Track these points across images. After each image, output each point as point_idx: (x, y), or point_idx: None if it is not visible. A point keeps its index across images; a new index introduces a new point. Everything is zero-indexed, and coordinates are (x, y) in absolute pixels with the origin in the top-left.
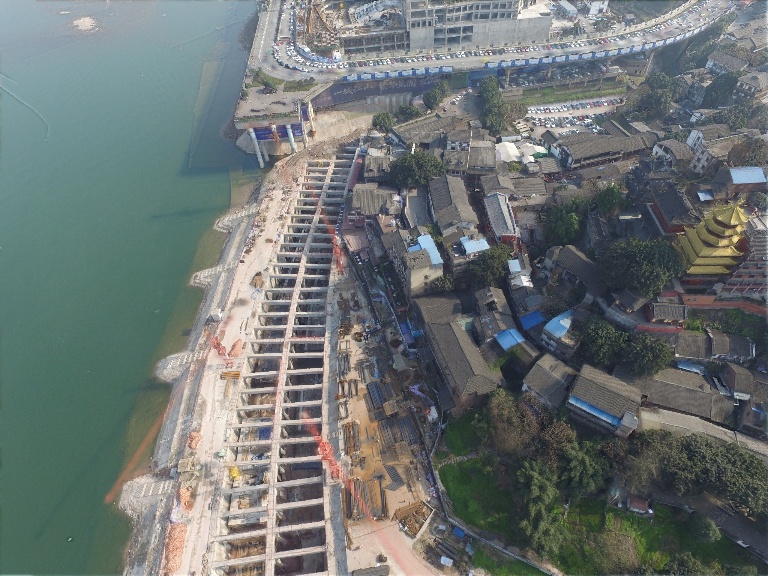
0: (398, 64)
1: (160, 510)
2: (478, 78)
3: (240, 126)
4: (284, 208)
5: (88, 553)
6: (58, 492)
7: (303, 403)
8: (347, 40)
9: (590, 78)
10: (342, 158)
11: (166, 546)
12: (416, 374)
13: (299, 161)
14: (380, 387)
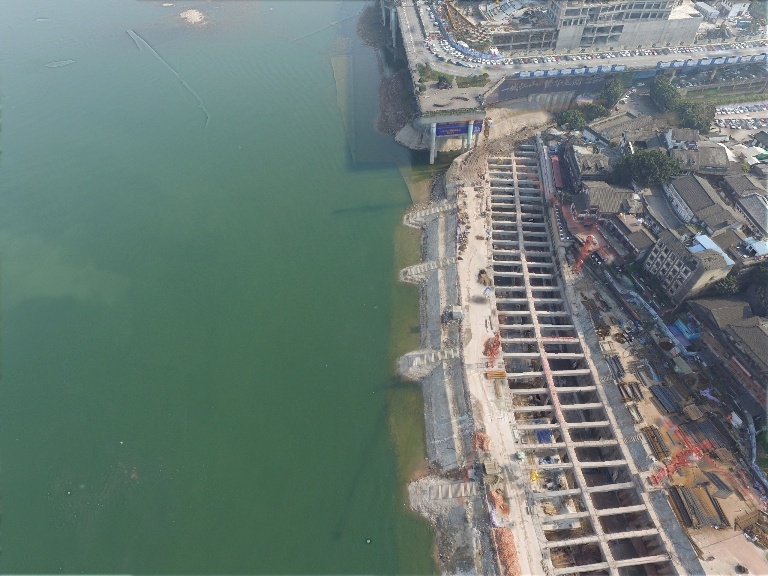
0: (564, 62)
1: (470, 513)
2: (636, 78)
3: (425, 121)
4: (482, 205)
5: (395, 556)
6: (341, 492)
7: (583, 405)
8: (496, 37)
9: (756, 80)
10: (520, 156)
11: (499, 551)
12: (701, 378)
13: (480, 158)
14: (666, 391)
